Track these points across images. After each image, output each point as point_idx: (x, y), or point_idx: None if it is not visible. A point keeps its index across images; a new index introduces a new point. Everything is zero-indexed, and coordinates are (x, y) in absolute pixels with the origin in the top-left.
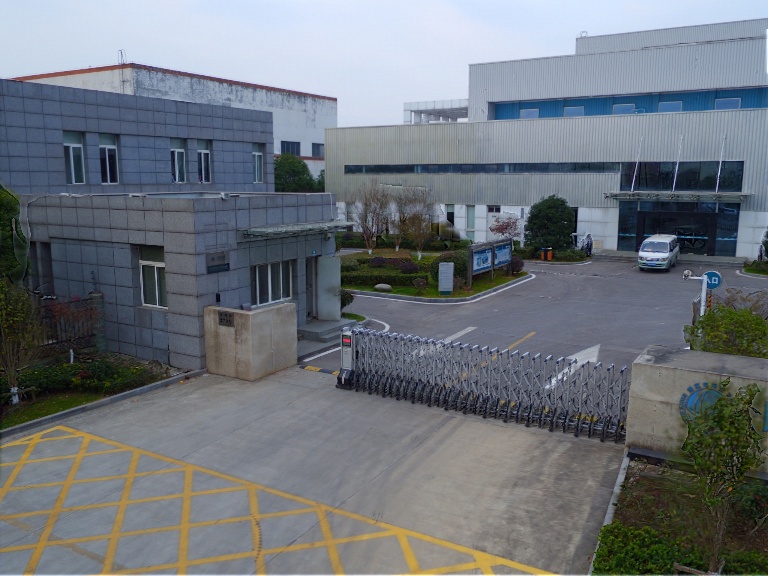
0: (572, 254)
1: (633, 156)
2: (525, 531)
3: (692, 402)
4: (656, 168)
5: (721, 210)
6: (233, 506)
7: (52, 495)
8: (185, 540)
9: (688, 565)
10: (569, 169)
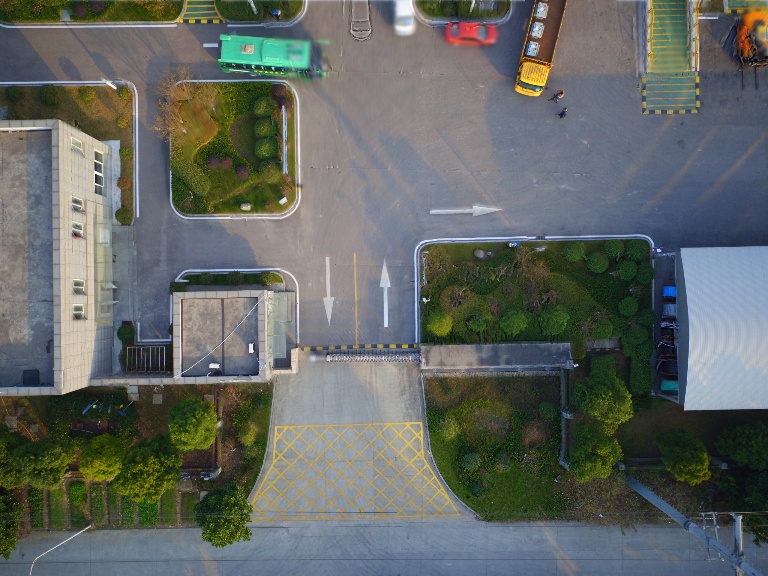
0: (295, 7)
1: None
2: (411, 412)
3: None
4: None
5: None
6: (353, 434)
7: (313, 452)
8: (354, 449)
9: (442, 419)
10: None
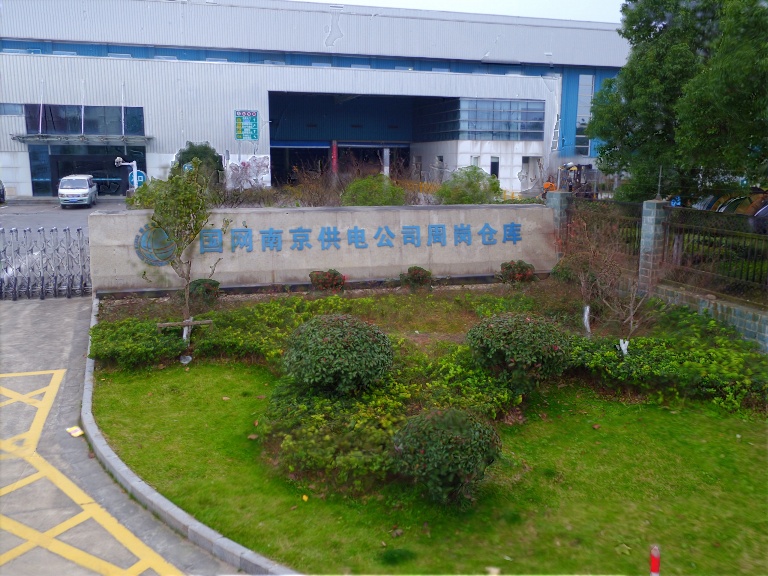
0: None
1: (36, 98)
2: (15, 356)
3: (144, 241)
4: (62, 111)
5: (129, 153)
6: None
7: None
8: None
9: None
10: None
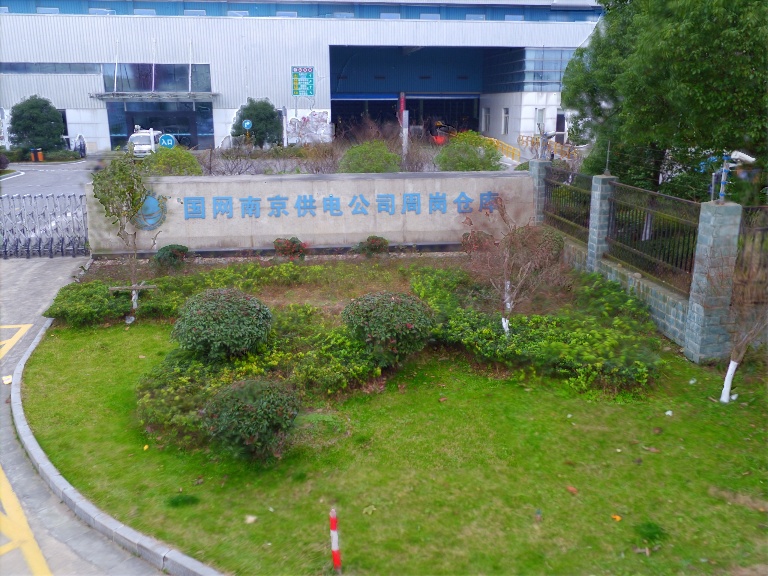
0: (64, 154)
1: (112, 57)
2: None
3: None
4: (135, 70)
5: (198, 109)
6: None
7: None
8: None
9: None
10: (49, 70)
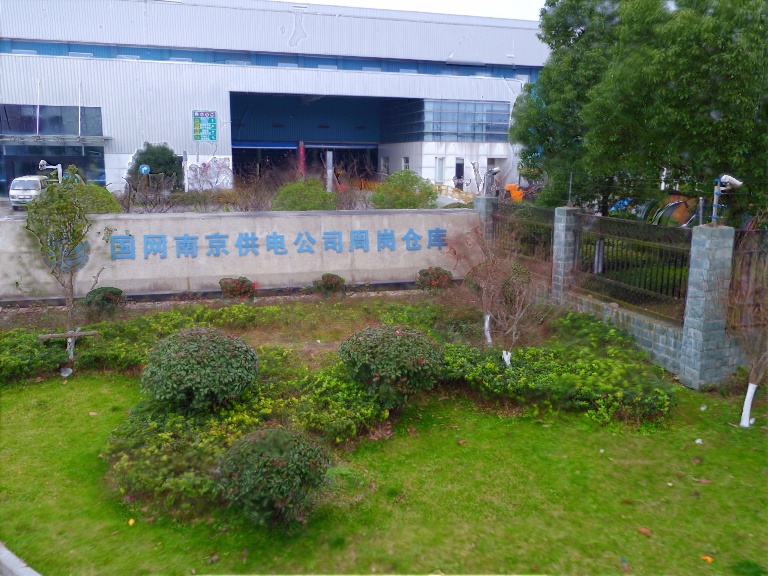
0: None
1: None
2: None
3: None
4: (17, 111)
5: (87, 153)
6: None
7: None
8: None
9: None
10: None
